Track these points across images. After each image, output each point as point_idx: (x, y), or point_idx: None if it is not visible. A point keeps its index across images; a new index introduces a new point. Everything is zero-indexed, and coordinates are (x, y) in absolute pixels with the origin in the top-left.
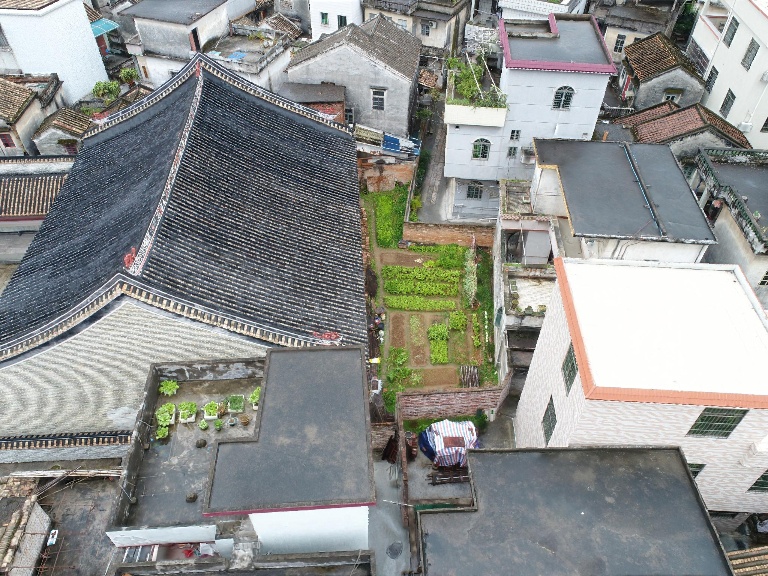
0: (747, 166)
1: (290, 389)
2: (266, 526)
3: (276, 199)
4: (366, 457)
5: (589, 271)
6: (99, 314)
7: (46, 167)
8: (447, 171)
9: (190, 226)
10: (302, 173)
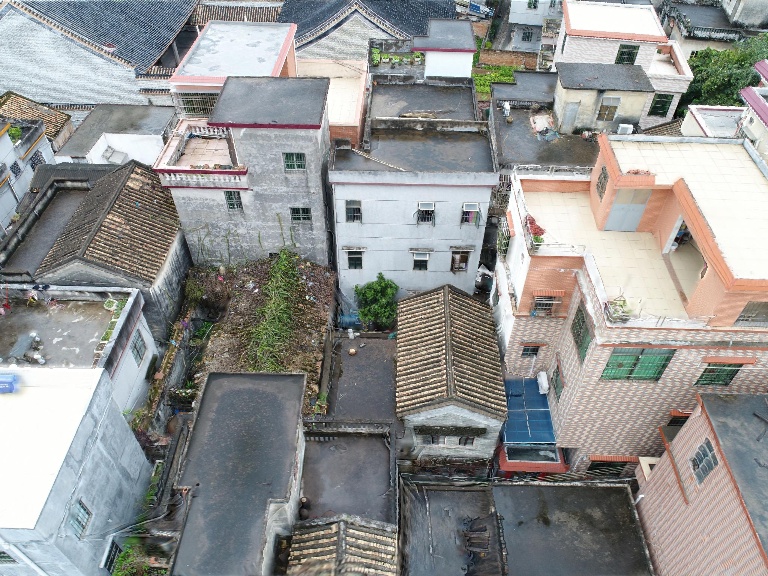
0: (694, 5)
1: (440, 27)
2: (431, 69)
3: (412, 8)
4: (473, 42)
5: (579, 5)
6: (341, 23)
7: (265, 5)
8: (511, 18)
9: (374, 3)
10: (425, 2)
